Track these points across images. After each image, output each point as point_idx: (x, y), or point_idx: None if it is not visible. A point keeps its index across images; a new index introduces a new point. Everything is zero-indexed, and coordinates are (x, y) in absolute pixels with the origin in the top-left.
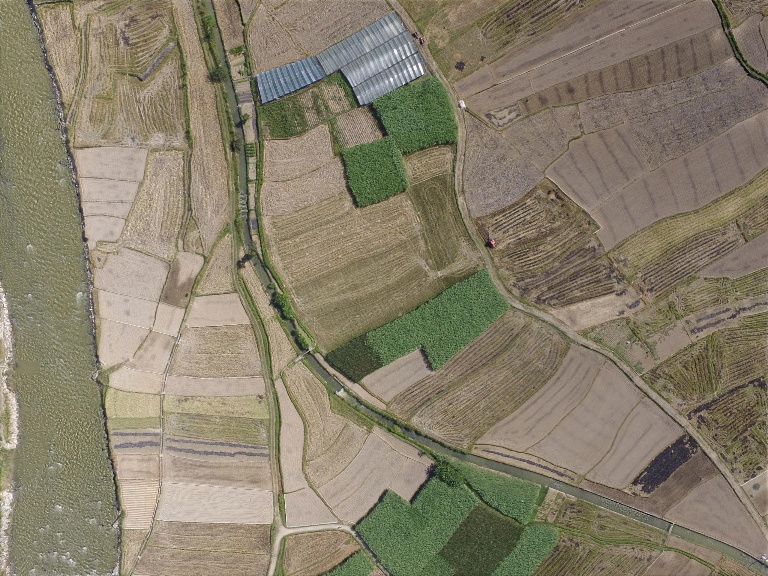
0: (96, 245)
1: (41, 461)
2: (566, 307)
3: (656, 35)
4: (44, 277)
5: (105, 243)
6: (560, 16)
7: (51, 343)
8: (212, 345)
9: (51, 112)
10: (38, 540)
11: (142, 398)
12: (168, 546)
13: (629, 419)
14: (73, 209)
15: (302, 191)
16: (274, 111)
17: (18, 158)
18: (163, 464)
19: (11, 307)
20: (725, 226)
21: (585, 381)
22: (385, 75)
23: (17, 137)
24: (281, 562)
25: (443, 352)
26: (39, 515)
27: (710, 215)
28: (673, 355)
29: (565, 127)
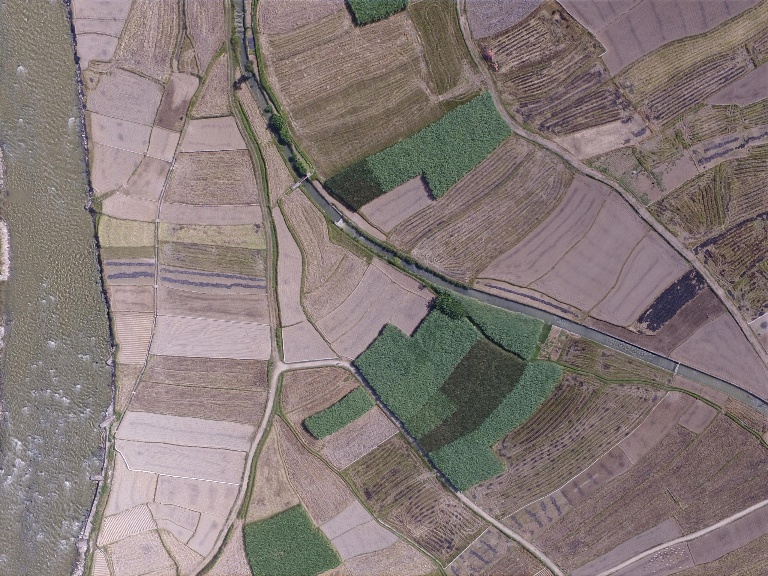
0: (88, 65)
1: (33, 295)
2: (570, 135)
3: None
4: (35, 101)
5: (98, 63)
6: None
7: (43, 171)
8: (208, 171)
9: None
10: (30, 377)
11: (136, 226)
12: (163, 382)
13: (634, 253)
14: (65, 29)
15: (300, 8)
16: None
17: None
18: (158, 296)
19: (1, 132)
20: (734, 50)
21: (590, 213)
22: None
23: None
24: (279, 399)
25: (444, 178)
26: (31, 350)
27: (719, 39)
28: (680, 186)
29: None
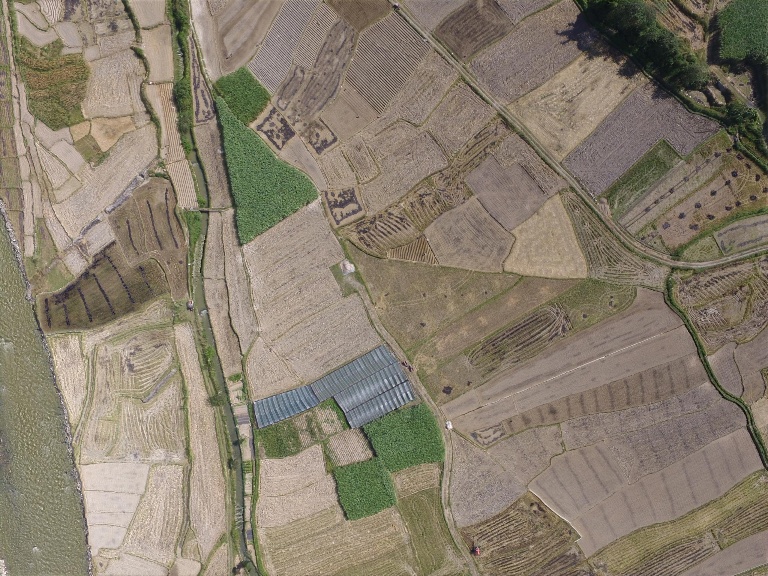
0: (99, 552)
1: None
2: None
3: (635, 361)
4: None
5: (107, 550)
6: (543, 345)
7: None
8: None
9: (58, 426)
10: None
11: None
12: None
13: None
14: (77, 514)
15: (295, 505)
16: (270, 434)
17: (26, 468)
18: None
19: None
20: (701, 535)
21: None
22: (376, 402)
23: (26, 450)
24: None
25: None
26: None
27: (686, 525)
28: None
29: (547, 445)
